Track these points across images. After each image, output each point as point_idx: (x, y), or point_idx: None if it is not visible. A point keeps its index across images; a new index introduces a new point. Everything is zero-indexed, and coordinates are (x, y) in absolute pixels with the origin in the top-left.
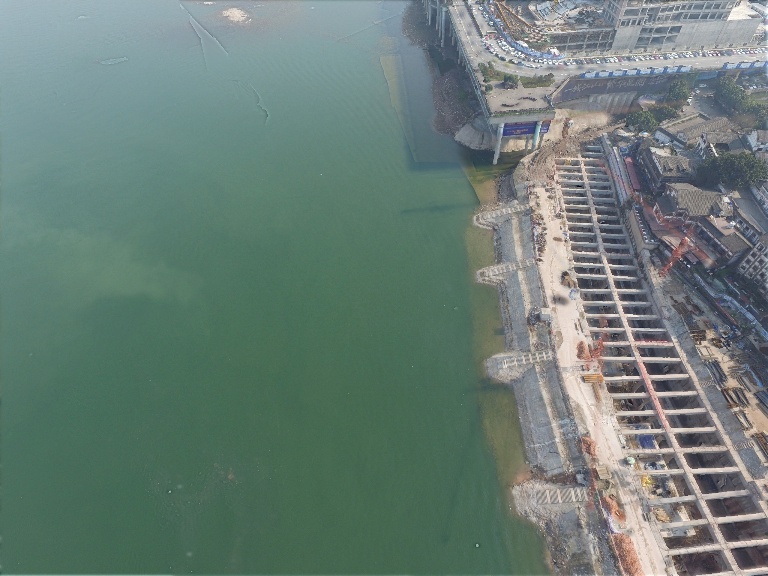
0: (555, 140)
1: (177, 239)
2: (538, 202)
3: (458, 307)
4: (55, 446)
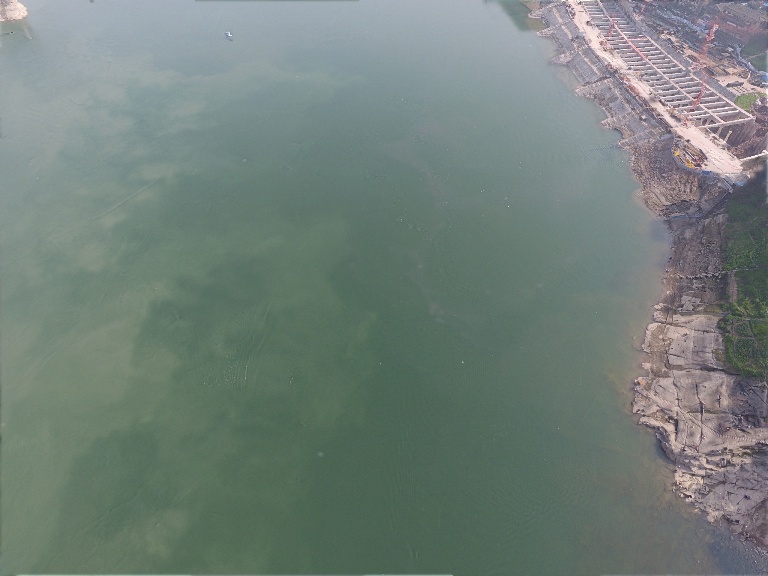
0: None
1: (354, 32)
2: None
3: (531, 45)
4: (339, 96)
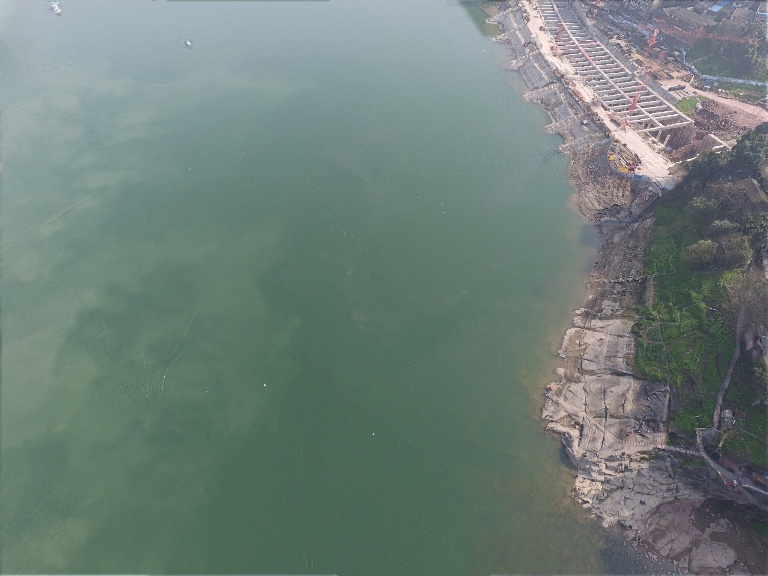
0: None
1: (312, 40)
2: (523, 5)
3: (485, 50)
4: None
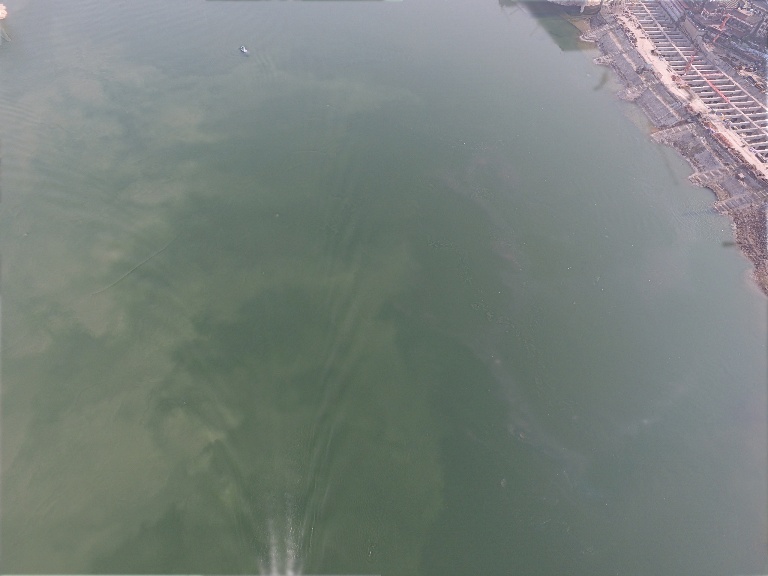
0: None
1: (387, 52)
2: (624, 22)
3: (589, 74)
4: (381, 134)
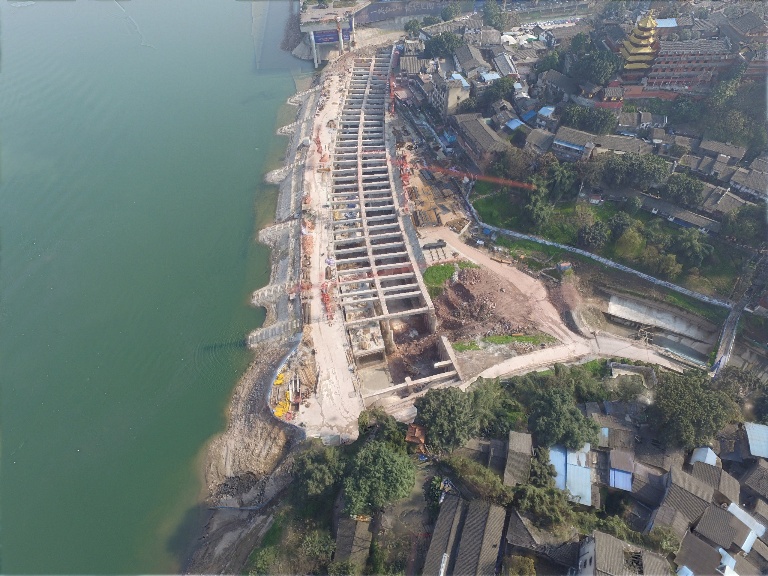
0: (360, 48)
1: (63, 120)
2: (330, 83)
3: (258, 148)
4: None
